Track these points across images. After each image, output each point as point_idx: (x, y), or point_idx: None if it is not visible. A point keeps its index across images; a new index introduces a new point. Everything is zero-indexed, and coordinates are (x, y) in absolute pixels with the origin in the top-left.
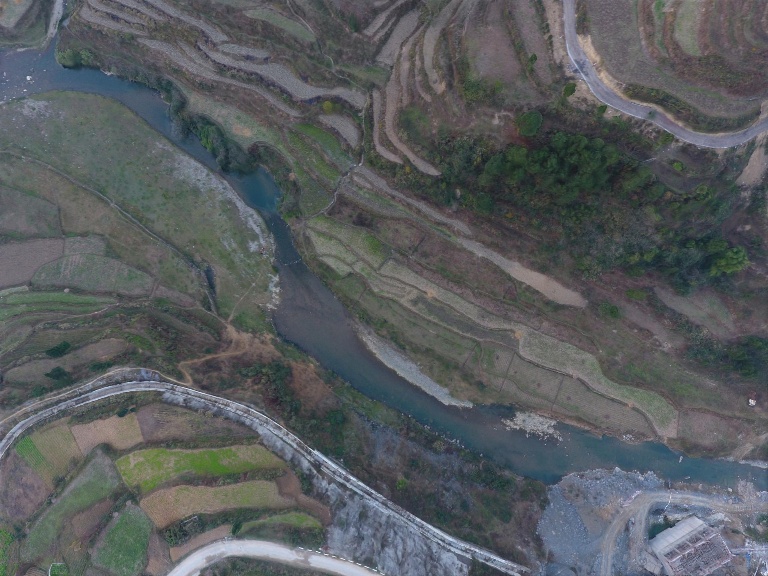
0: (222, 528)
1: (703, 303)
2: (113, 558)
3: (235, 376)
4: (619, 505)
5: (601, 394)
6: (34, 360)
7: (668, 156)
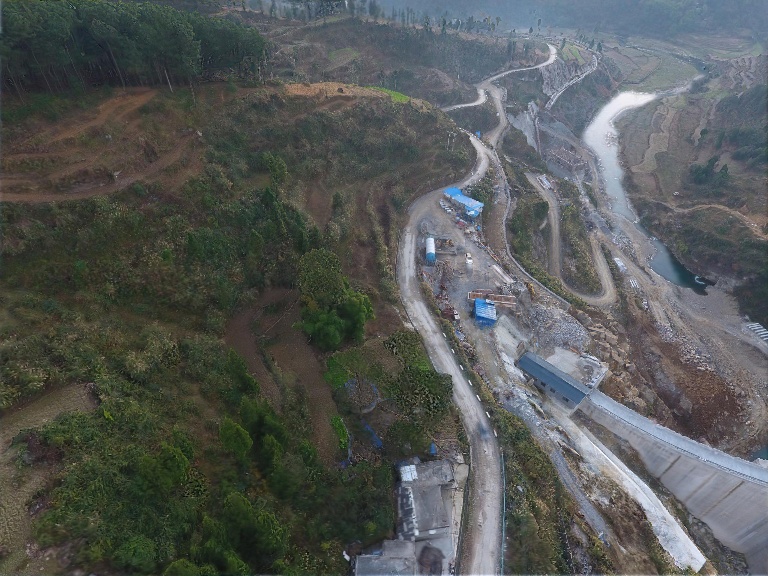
0: (558, 47)
1: (734, 165)
2: None
3: None
4: None
5: None
6: None
7: None
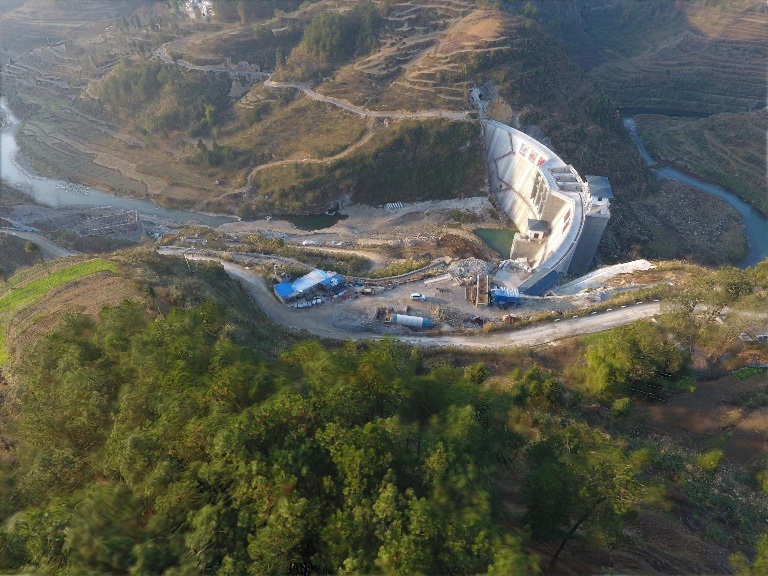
0: None
1: (203, 140)
2: None
3: None
4: (89, 208)
5: (126, 176)
6: None
7: None
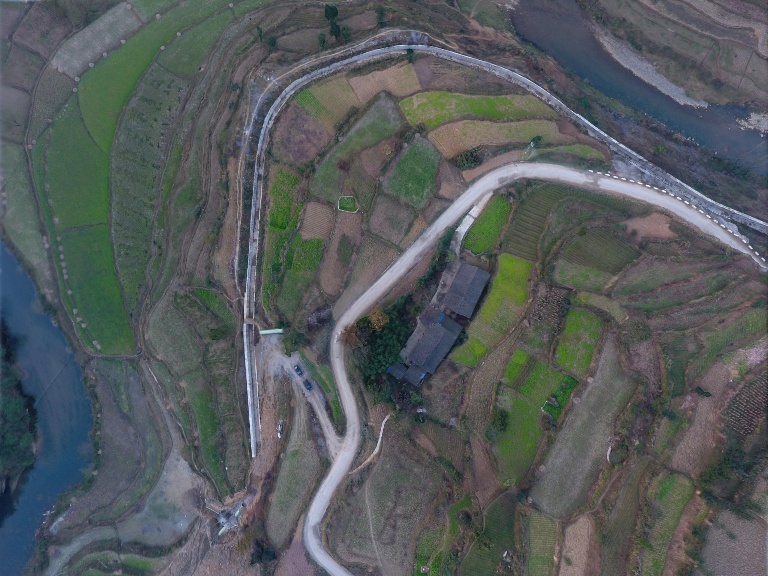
0: (513, 153)
1: None
2: (403, 186)
3: (493, 50)
4: None
5: None
6: (302, 29)
7: None
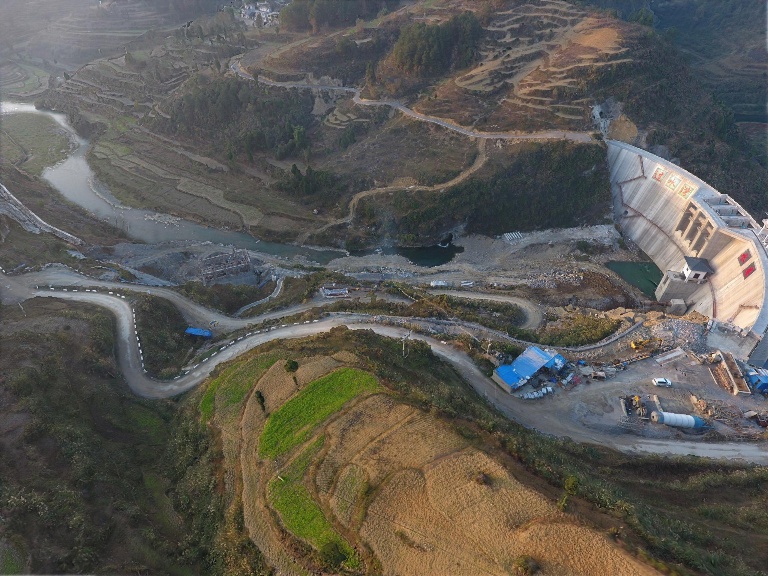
0: None
1: (292, 163)
2: None
3: None
4: None
5: (216, 205)
6: None
7: (264, 90)
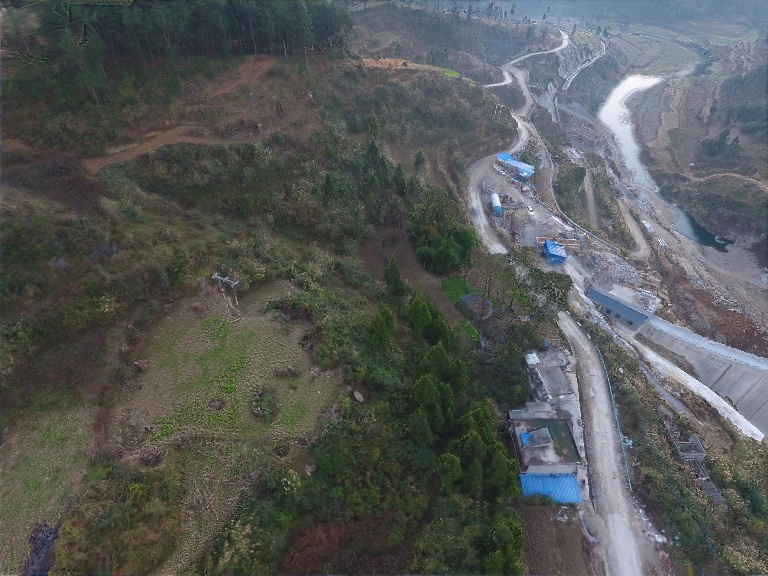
0: None
1: (743, 138)
2: None
3: None
4: (601, 126)
5: None
6: None
7: None
